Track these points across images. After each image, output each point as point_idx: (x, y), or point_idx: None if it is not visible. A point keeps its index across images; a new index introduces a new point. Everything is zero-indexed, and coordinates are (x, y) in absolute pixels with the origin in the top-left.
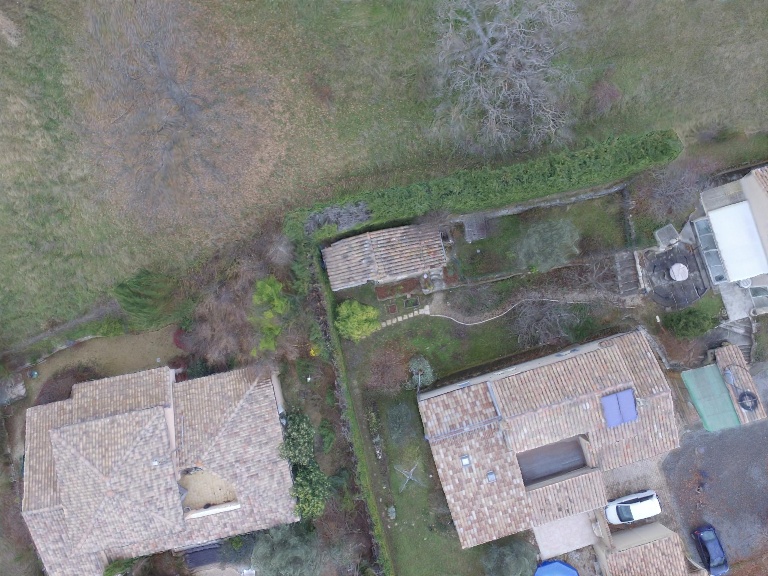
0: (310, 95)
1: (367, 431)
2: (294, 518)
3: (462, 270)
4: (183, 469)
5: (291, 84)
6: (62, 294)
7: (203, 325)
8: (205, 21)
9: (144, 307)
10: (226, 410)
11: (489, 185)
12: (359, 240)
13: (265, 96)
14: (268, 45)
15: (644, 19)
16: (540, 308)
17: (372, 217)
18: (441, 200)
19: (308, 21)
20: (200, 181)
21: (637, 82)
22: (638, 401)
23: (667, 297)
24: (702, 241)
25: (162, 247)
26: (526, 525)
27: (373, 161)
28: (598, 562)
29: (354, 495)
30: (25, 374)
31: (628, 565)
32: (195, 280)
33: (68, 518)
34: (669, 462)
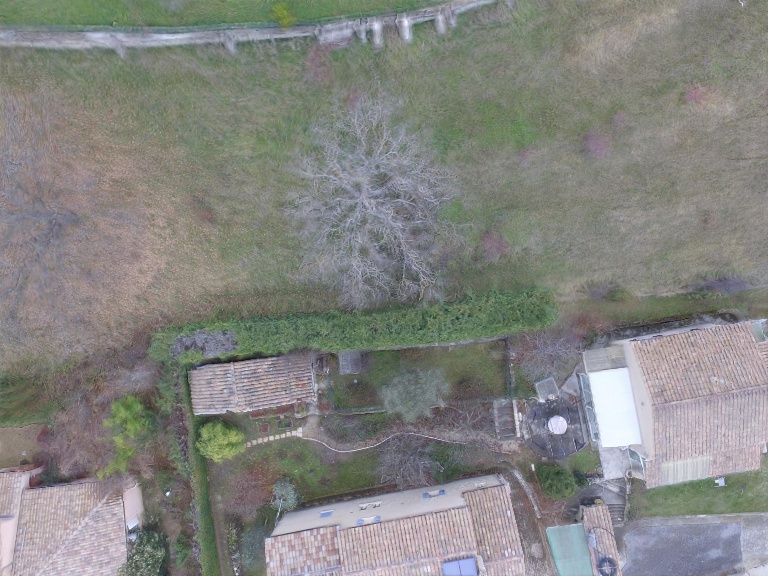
0: (190, 214)
1: (227, 546)
2: None
3: (337, 398)
4: None
5: (171, 202)
6: None
7: (58, 436)
8: (82, 136)
9: None
10: (70, 526)
11: (357, 331)
12: (223, 369)
13: (146, 210)
14: (148, 163)
15: (538, 175)
16: (414, 443)
17: (236, 349)
18: (306, 341)
19: (189, 145)
20: (74, 286)
21: (527, 236)
22: (481, 570)
23: (543, 448)
24: (586, 395)
25: (32, 347)
26: None
27: (253, 283)
28: None
29: None
30: None
31: None
32: (61, 384)
33: None
34: None
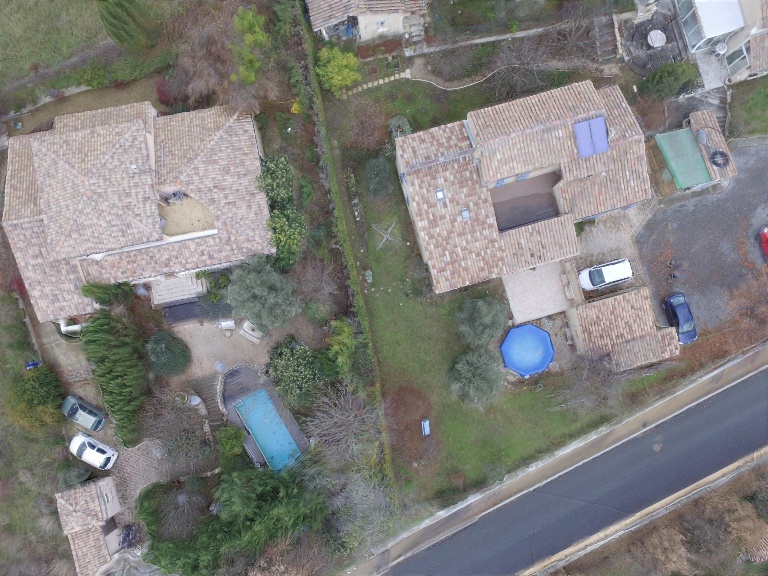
0: None
1: (346, 193)
2: (270, 248)
3: (443, 31)
4: (162, 192)
5: None
6: (47, 37)
7: (185, 58)
8: None
9: (126, 24)
10: (206, 138)
11: None
12: None
13: None
14: None
15: None
16: None
17: None
18: None
19: None
20: None
21: None
22: (610, 130)
23: (644, 65)
24: (680, 11)
25: None
26: (499, 270)
27: None
28: (570, 328)
29: (331, 240)
30: (9, 124)
31: (598, 318)
32: (179, 23)
33: (47, 223)
34: (642, 236)
